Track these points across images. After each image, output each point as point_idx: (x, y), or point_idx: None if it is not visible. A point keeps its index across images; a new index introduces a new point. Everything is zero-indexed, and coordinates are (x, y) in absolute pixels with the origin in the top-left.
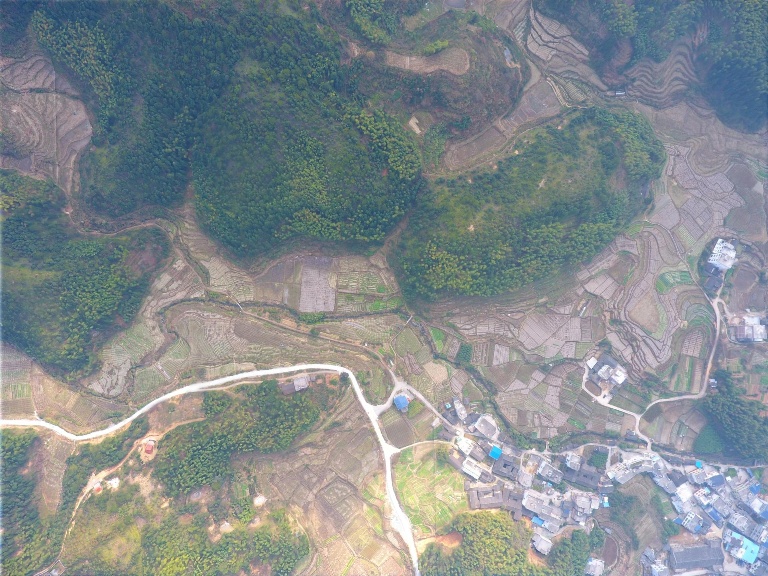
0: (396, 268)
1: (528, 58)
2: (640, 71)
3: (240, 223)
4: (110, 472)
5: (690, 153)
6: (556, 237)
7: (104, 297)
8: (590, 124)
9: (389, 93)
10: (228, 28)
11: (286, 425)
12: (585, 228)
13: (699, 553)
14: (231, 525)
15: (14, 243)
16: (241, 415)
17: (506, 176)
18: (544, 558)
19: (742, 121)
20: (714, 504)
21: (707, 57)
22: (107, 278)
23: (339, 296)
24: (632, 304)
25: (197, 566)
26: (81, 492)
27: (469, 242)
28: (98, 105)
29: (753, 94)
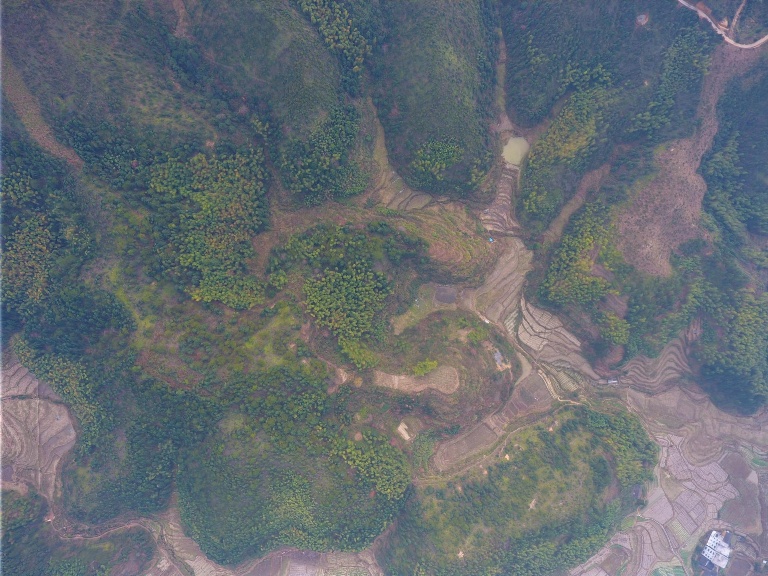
0: (385, 569)
1: (519, 351)
2: (633, 364)
3: (225, 546)
4: None
5: (683, 442)
6: (547, 553)
7: None
8: (582, 430)
9: (377, 406)
10: (211, 401)
11: None
12: (576, 544)
13: None
14: None
15: None
16: None
17: (496, 490)
18: None
19: (736, 407)
20: None
21: (700, 359)
22: None
23: None
24: None
25: None
26: None
27: (458, 569)
28: None
29: (747, 394)
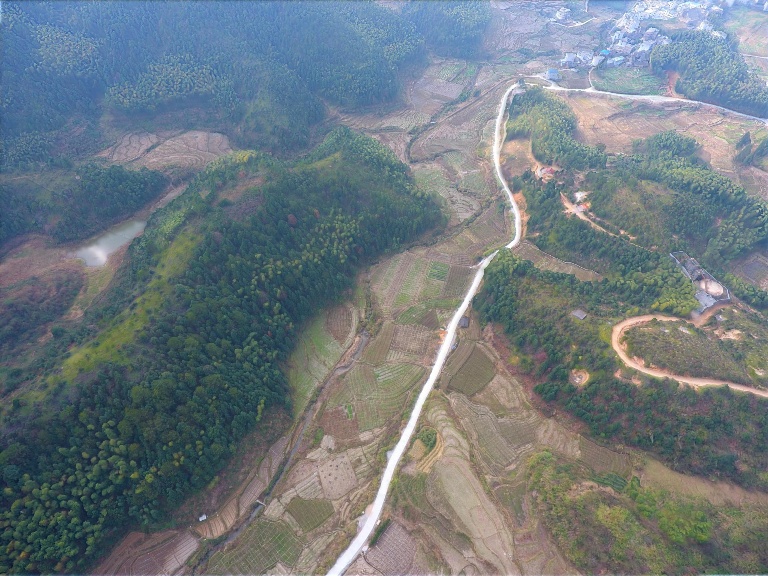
0: (450, 50)
1: None
2: None
3: (373, 67)
4: (567, 200)
5: None
6: None
7: None
8: None
9: None
10: None
11: None
12: None
13: (692, 14)
14: None
15: None
16: None
17: None
18: None
19: None
20: (659, 6)
21: None
22: None
23: (454, 82)
24: None
25: None
26: None
27: None
28: (207, 116)
29: None
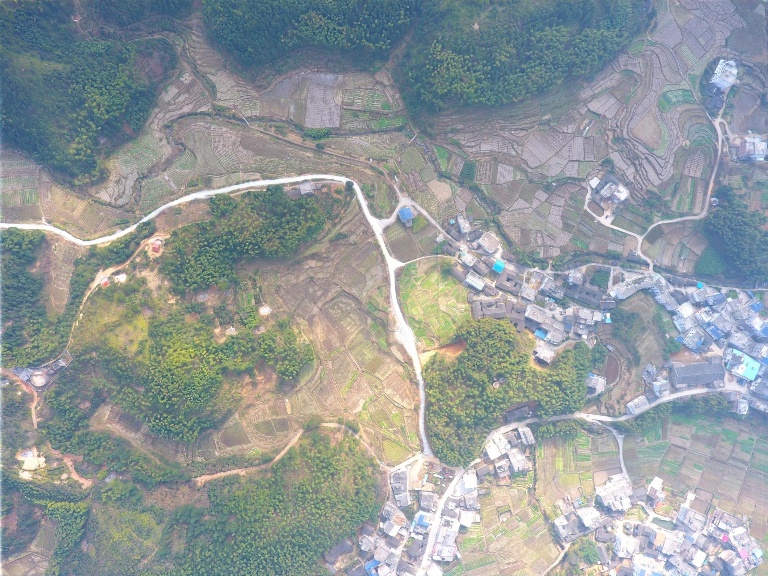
0: (401, 82)
1: None
2: None
3: (247, 22)
4: (117, 269)
5: None
6: (560, 42)
7: (112, 95)
8: None
9: None
10: None
11: (292, 225)
12: (588, 33)
13: (700, 368)
14: (237, 330)
15: (24, 34)
16: (247, 213)
17: None
18: (547, 368)
19: None
20: (715, 321)
21: None
22: (115, 76)
23: (344, 113)
24: (635, 121)
25: (203, 360)
26: (89, 287)
27: (474, 40)
28: None
29: None
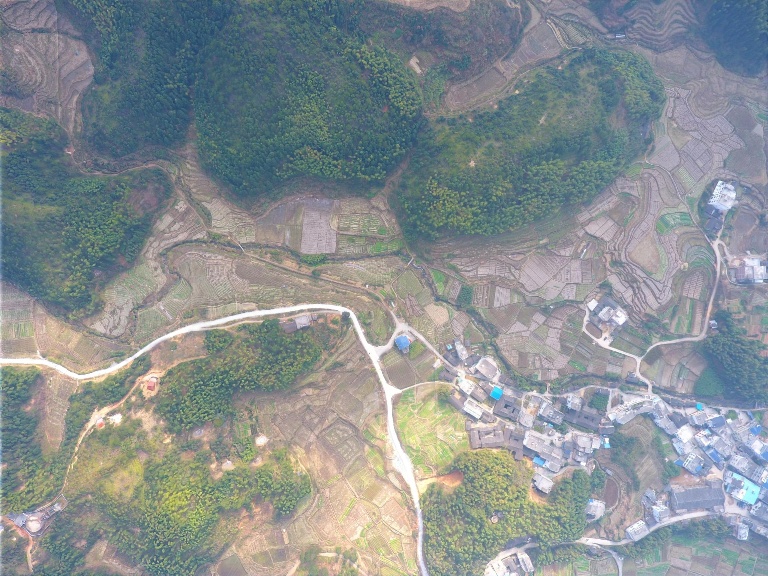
0: (397, 209)
1: None
2: (640, 13)
3: (242, 160)
4: (112, 408)
5: (690, 96)
6: (556, 174)
7: (106, 234)
8: (590, 63)
9: (390, 31)
10: None
11: (288, 362)
12: (585, 165)
13: (700, 493)
14: (233, 464)
15: (17, 178)
16: (243, 351)
17: (506, 114)
18: (545, 497)
19: (742, 64)
20: (715, 445)
21: None
22: (109, 215)
23: (340, 238)
24: (632, 245)
25: (199, 501)
26: (84, 427)
27: (470, 177)
28: (100, 45)
29: (753, 34)
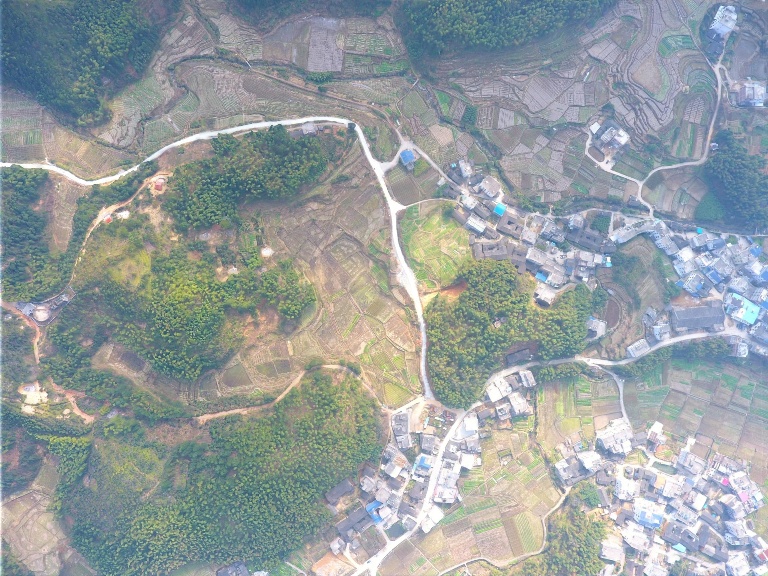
0: (403, 25)
1: None
2: None
3: None
4: (120, 206)
5: None
6: None
7: (116, 34)
8: None
9: None
10: None
11: (294, 164)
12: None
13: (700, 311)
14: (239, 270)
15: None
16: (250, 151)
17: None
18: None
19: None
20: (715, 265)
21: None
22: (119, 14)
23: (346, 57)
24: (635, 66)
25: (205, 296)
26: (91, 223)
27: None
28: None
29: None
